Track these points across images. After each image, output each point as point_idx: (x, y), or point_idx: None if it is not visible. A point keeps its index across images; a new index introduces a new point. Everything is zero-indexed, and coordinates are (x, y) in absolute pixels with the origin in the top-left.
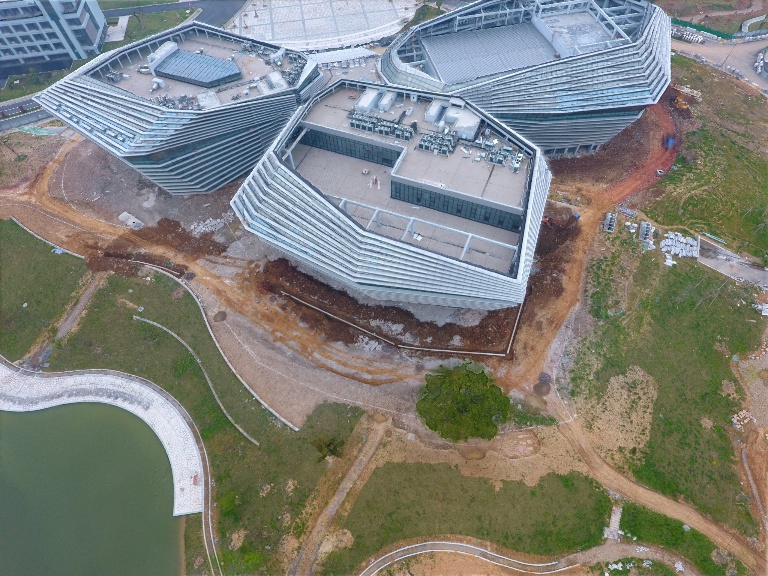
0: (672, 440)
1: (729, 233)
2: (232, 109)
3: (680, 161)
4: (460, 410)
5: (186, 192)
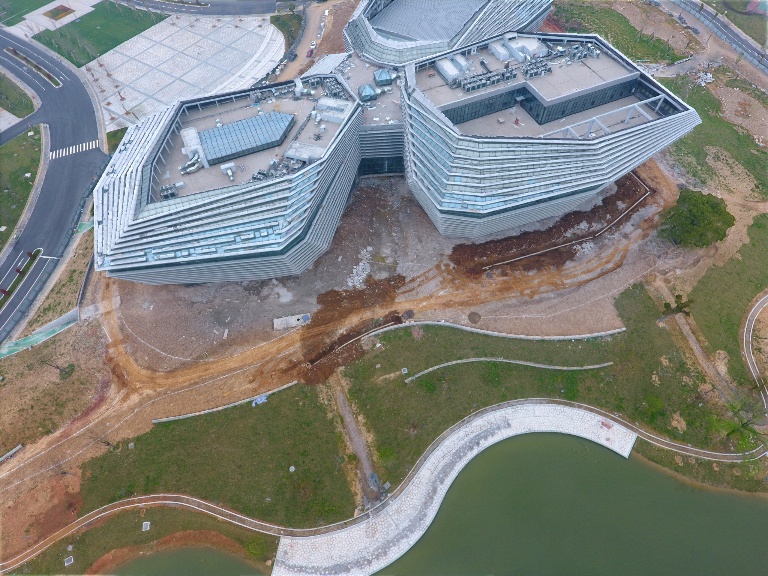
0: (759, 169)
1: (643, 55)
2: (337, 144)
3: (571, 31)
4: (717, 216)
5: (311, 262)
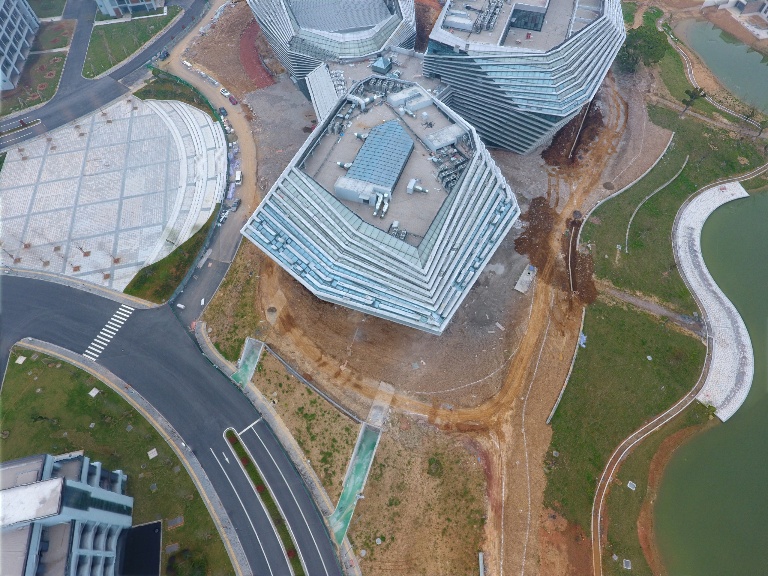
0: None
1: None
2: None
3: None
4: None
5: None
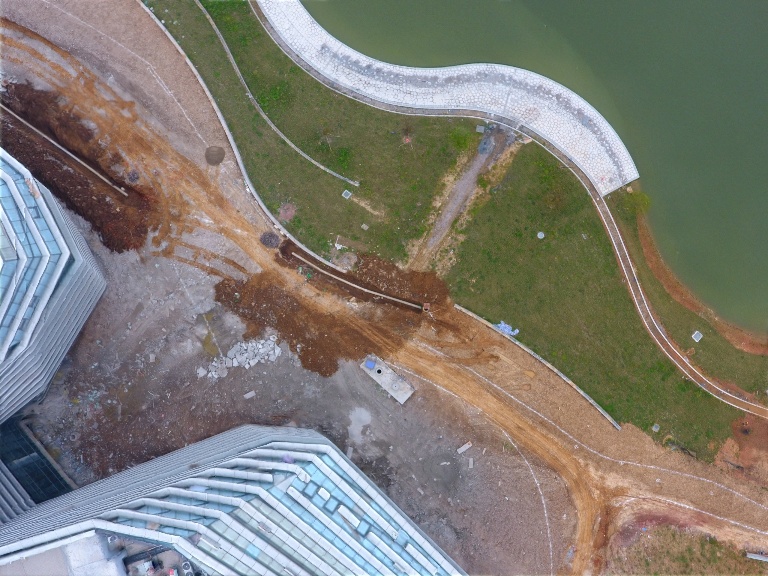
0: None
1: None
2: None
3: None
4: None
5: None
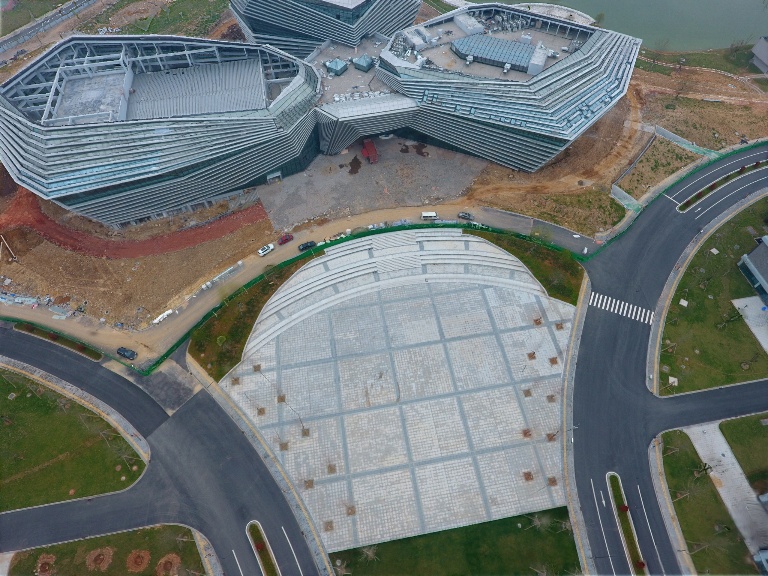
0: None
1: None
2: None
3: None
4: None
5: None
